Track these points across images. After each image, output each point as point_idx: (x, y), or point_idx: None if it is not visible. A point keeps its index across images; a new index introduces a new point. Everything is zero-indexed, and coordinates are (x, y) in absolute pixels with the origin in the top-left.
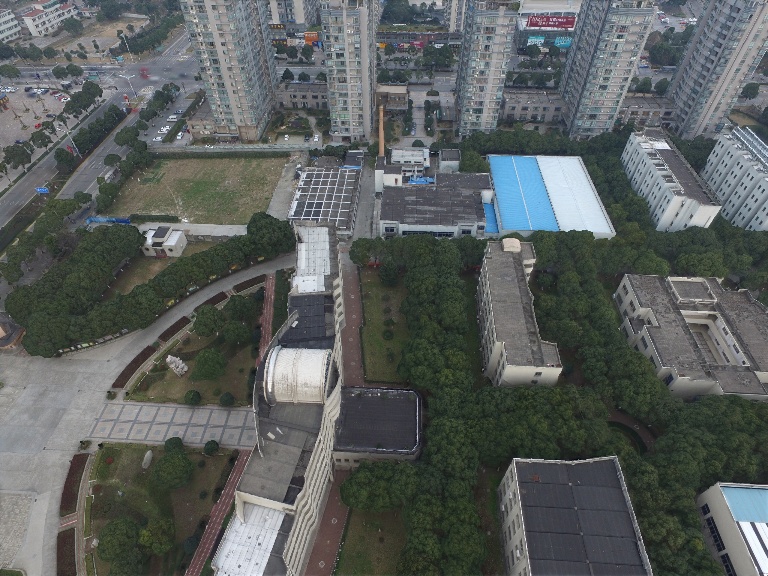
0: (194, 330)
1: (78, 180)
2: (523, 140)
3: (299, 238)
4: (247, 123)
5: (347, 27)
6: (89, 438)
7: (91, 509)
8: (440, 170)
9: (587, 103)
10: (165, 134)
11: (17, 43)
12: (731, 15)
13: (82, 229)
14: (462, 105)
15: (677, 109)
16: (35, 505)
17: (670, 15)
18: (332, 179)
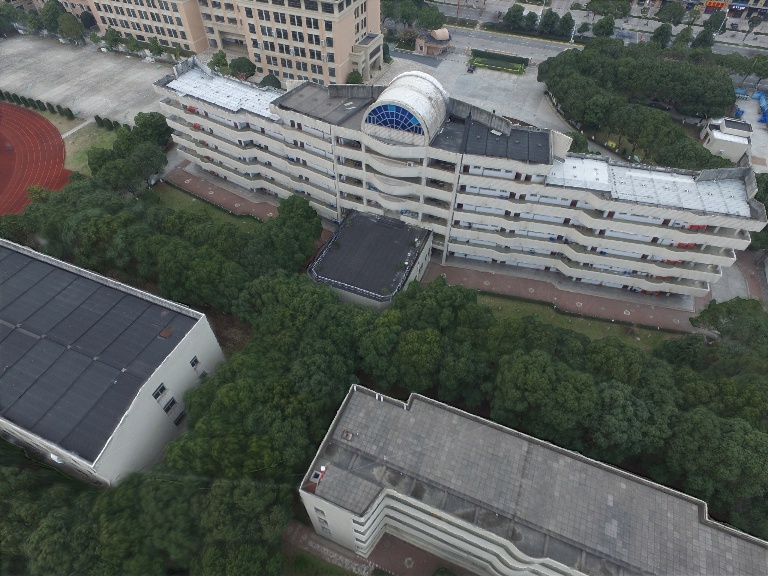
0: None
1: None
2: None
3: None
4: None
5: None
6: None
7: None
8: None
9: None
10: None
11: None
12: None
13: None
14: None
15: None
16: None
17: None
18: None
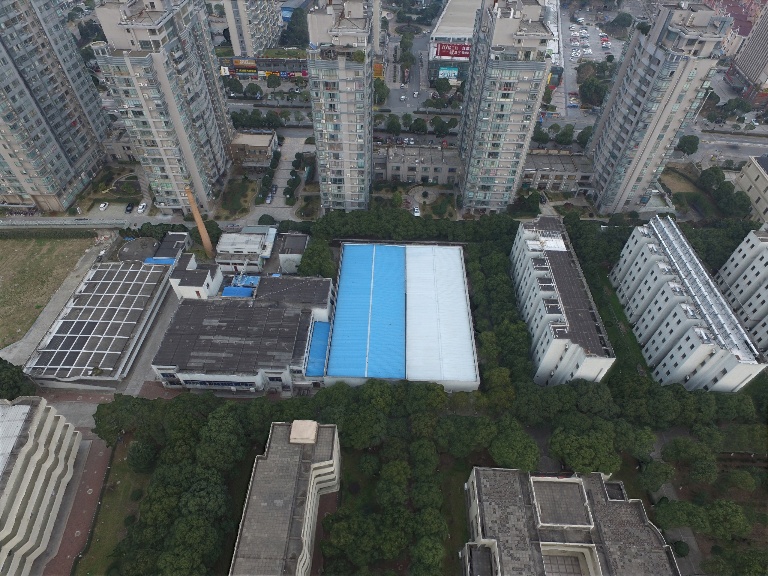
0: None
1: None
2: (388, 225)
3: None
4: (43, 191)
5: (137, 79)
6: None
7: None
8: (280, 264)
9: (476, 172)
10: None
11: None
12: (650, 67)
13: None
14: None
15: (596, 173)
16: None
17: (613, 38)
18: (126, 282)
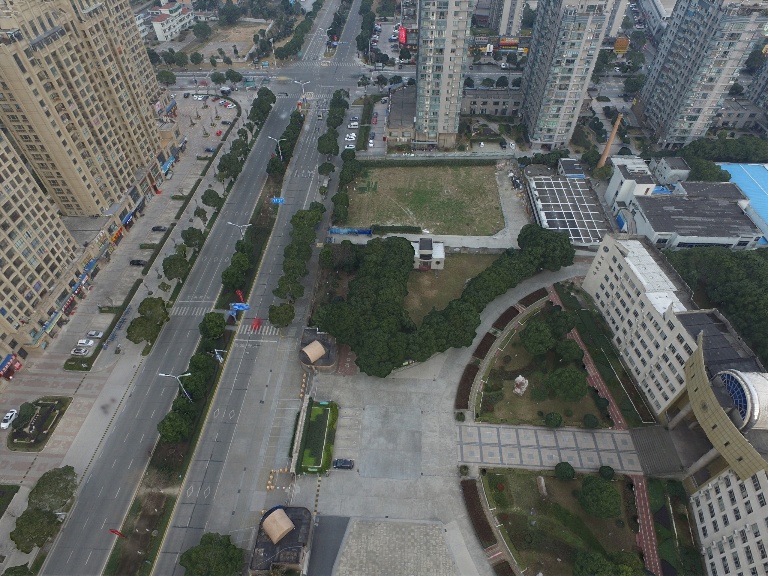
0: (504, 347)
1: (291, 189)
2: (752, 148)
3: (621, 252)
4: (449, 130)
5: (587, 33)
6: (463, 463)
7: (511, 540)
8: (666, 179)
9: None
10: (353, 141)
11: (148, 48)
12: None
13: (349, 241)
14: (674, 112)
15: None
16: (448, 535)
17: None
18: (566, 188)
